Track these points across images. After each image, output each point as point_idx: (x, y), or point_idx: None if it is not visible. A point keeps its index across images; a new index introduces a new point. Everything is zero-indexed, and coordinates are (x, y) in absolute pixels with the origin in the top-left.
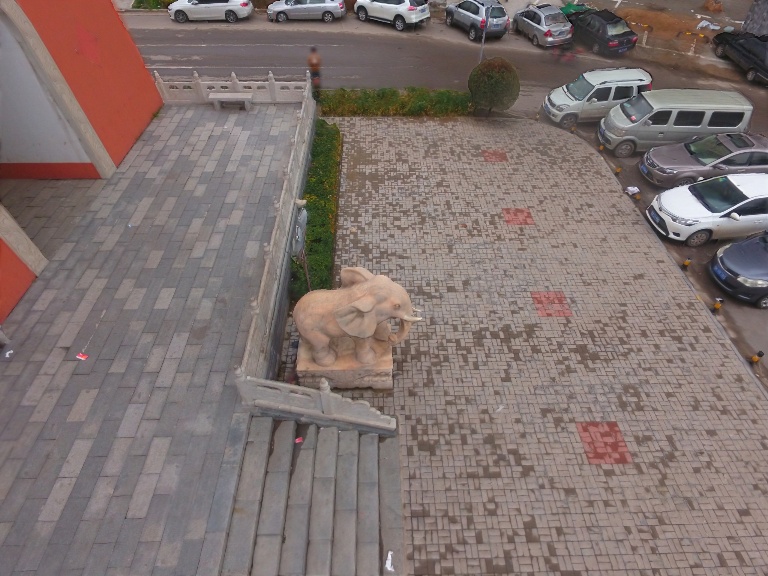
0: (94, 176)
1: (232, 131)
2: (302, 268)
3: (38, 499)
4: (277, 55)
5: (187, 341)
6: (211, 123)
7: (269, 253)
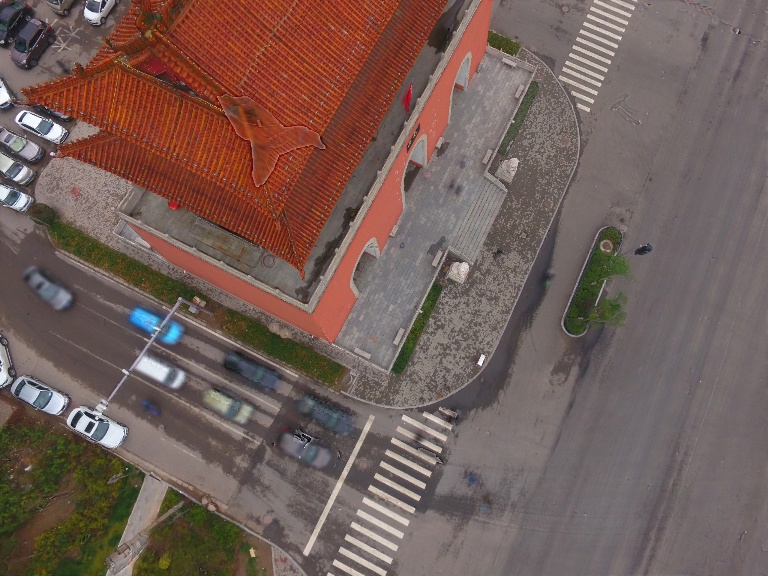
0: None
1: None
2: None
3: None
4: (96, 336)
5: None
6: None
7: None
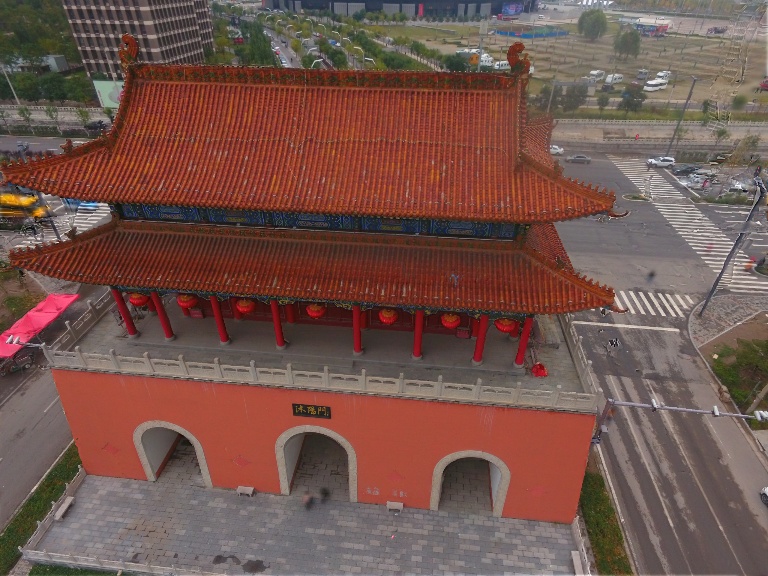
0: None
1: (547, 570)
2: None
3: (349, 540)
4: None
5: (396, 571)
6: (554, 556)
7: None
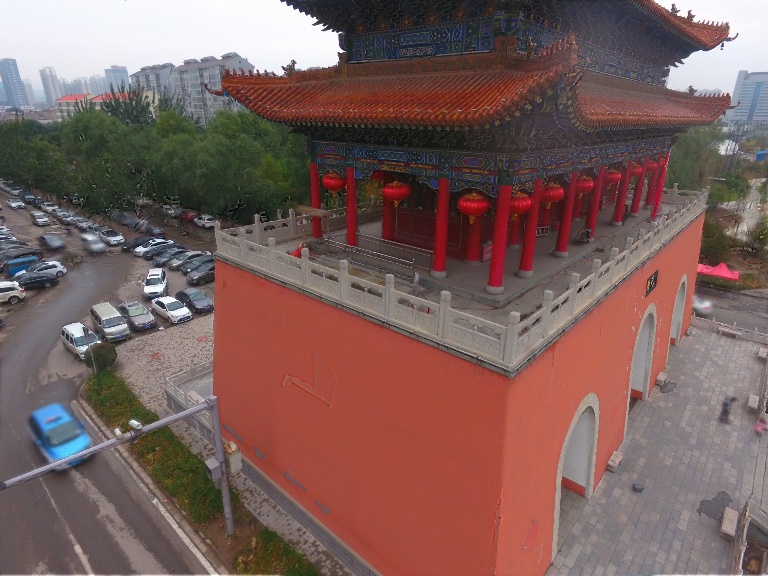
0: None
1: None
2: None
3: None
4: (4, 517)
5: None
6: None
7: None
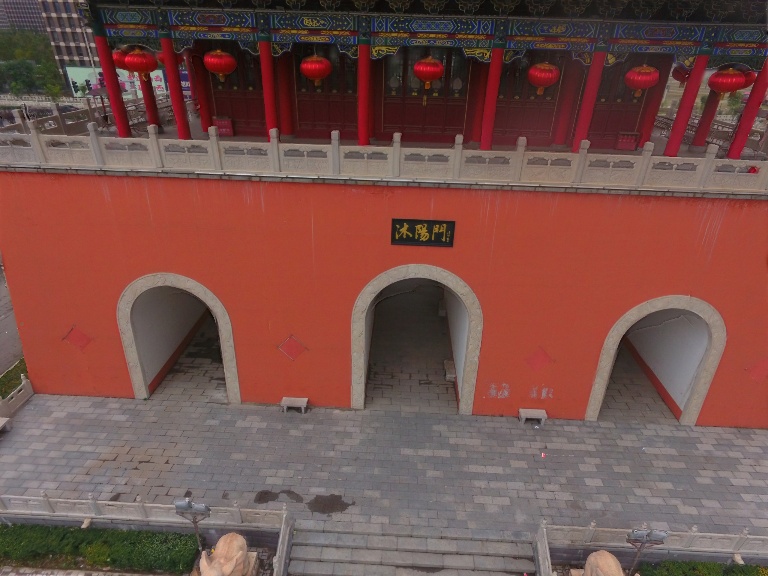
0: (677, 417)
1: None
2: (667, 570)
3: (476, 462)
4: None
5: (568, 500)
6: None
7: None
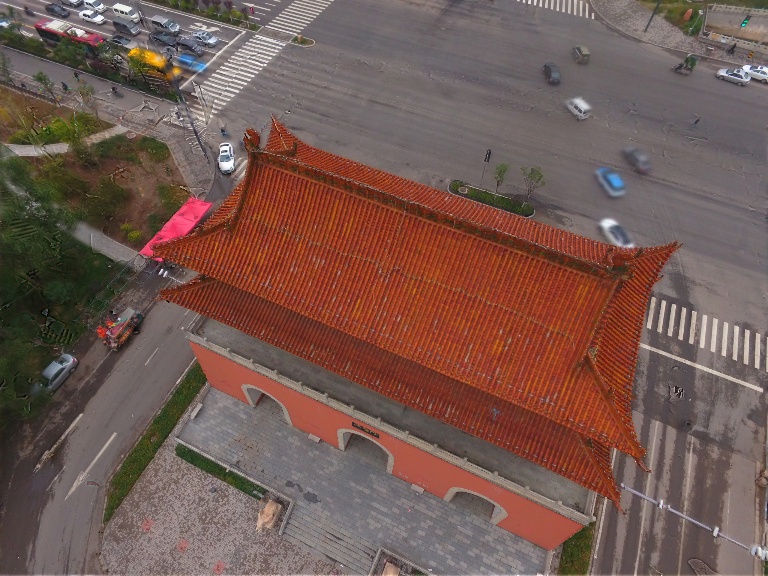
0: None
1: None
2: None
3: (378, 502)
4: None
5: (404, 536)
6: (523, 570)
7: (416, 567)
